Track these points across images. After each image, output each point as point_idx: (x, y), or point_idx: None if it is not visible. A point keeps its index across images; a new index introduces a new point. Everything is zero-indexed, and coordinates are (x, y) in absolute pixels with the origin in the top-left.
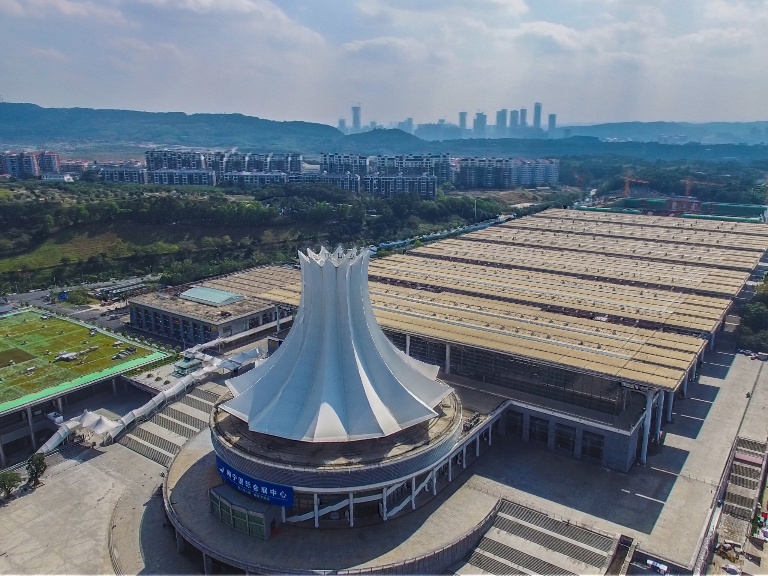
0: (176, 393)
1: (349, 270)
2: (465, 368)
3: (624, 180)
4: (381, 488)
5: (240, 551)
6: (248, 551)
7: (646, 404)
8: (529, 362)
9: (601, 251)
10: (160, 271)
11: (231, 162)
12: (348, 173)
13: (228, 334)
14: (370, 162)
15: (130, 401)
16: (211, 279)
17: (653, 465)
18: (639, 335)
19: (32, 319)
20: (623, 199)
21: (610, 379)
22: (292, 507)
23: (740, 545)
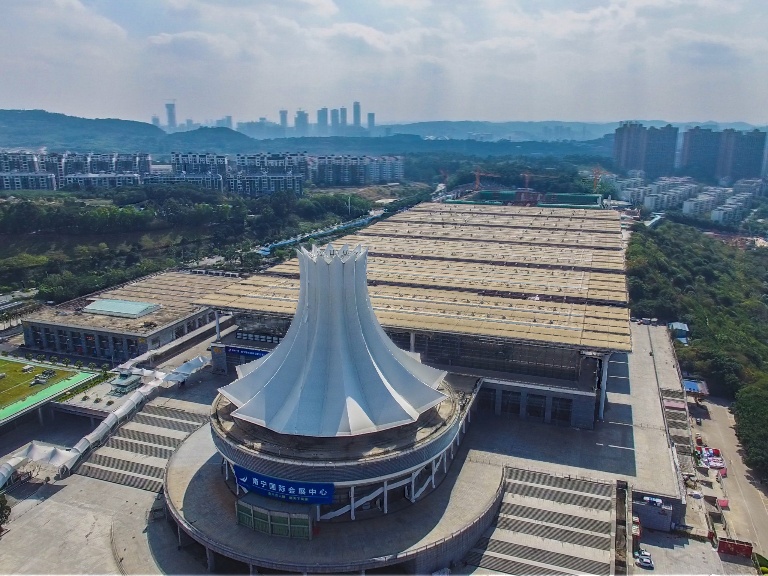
0: (127, 413)
1: (355, 266)
2: (430, 354)
3: (475, 175)
4: (414, 471)
5: (291, 555)
6: (299, 554)
7: (603, 368)
8: (495, 342)
9: (493, 239)
10: (30, 286)
11: (70, 163)
12: (209, 173)
13: (156, 346)
14: (228, 161)
15: (64, 429)
16: (107, 290)
17: (610, 420)
18: (575, 310)
19: None
20: (479, 192)
21: (571, 349)
22: (323, 505)
23: (694, 475)
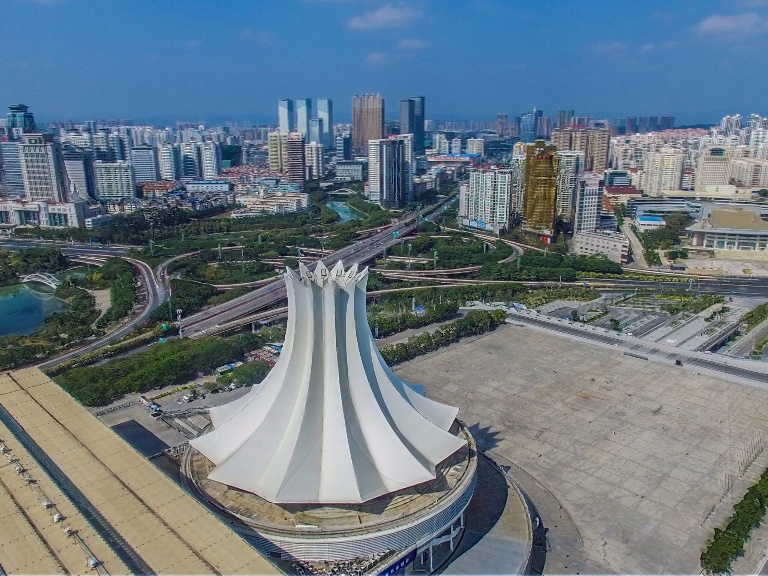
0: None
1: None
2: None
3: None
4: None
5: None
6: None
7: None
8: None
9: None
10: None
11: None
12: None
13: None
14: None
15: None
16: None
17: None
18: None
19: None
20: None
21: None
22: None
23: None
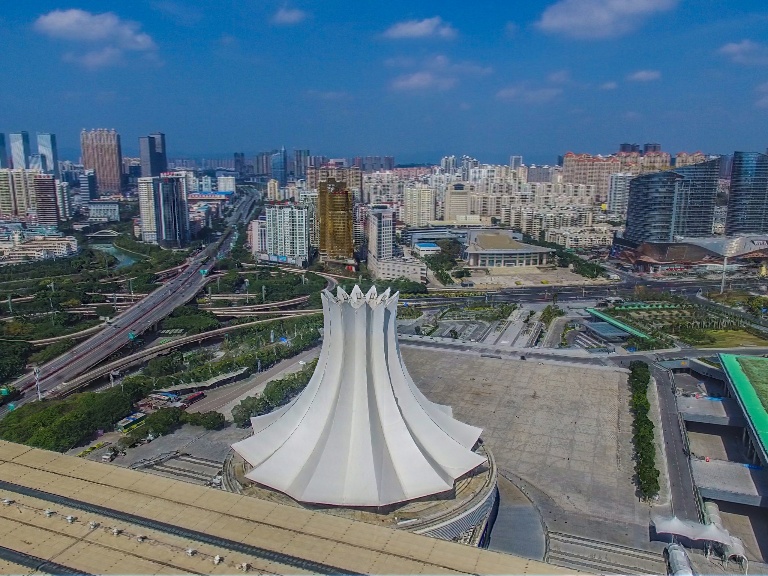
0: None
1: None
2: None
3: None
4: None
5: None
6: None
7: None
8: None
9: None
10: None
11: None
12: None
13: None
14: None
15: None
16: None
17: None
18: None
19: None
20: None
21: None
22: None
23: None
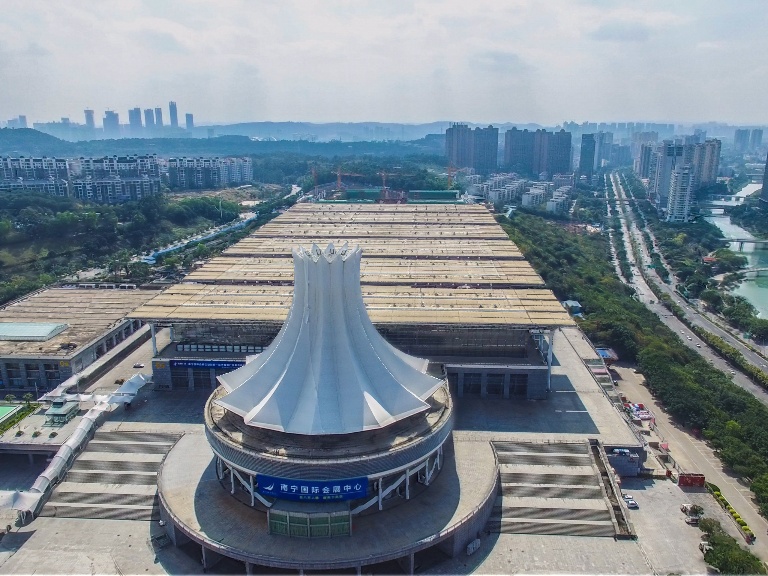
0: (79, 442)
1: None
2: None
3: (336, 174)
4: None
5: (340, 553)
6: (347, 550)
7: (549, 343)
8: (451, 329)
9: (390, 236)
10: None
11: None
12: (52, 178)
13: (79, 368)
14: (70, 165)
15: None
16: None
17: (557, 389)
18: (508, 294)
19: None
20: (345, 191)
21: (521, 329)
22: None
23: None
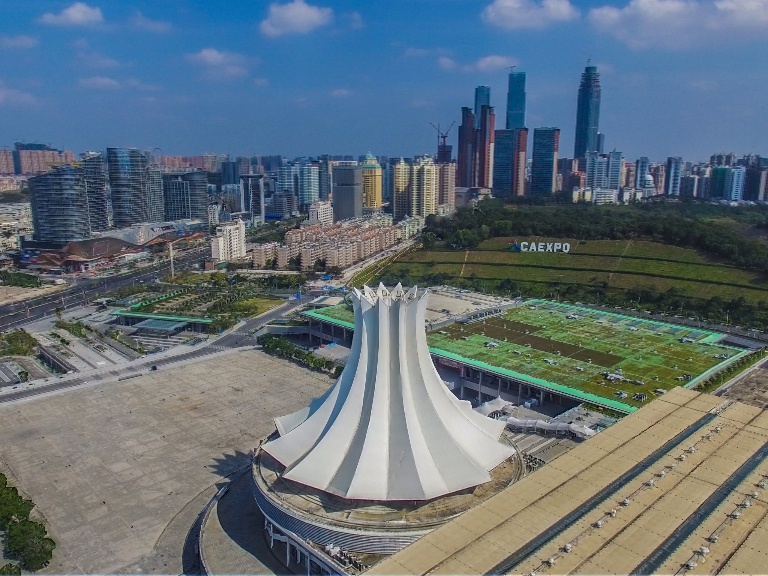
0: (547, 429)
1: None
2: None
3: None
4: None
5: None
6: None
7: None
8: None
9: None
10: None
11: None
12: None
13: None
14: None
15: None
16: None
17: None
18: None
19: (712, 353)
20: None
21: None
22: None
23: None
